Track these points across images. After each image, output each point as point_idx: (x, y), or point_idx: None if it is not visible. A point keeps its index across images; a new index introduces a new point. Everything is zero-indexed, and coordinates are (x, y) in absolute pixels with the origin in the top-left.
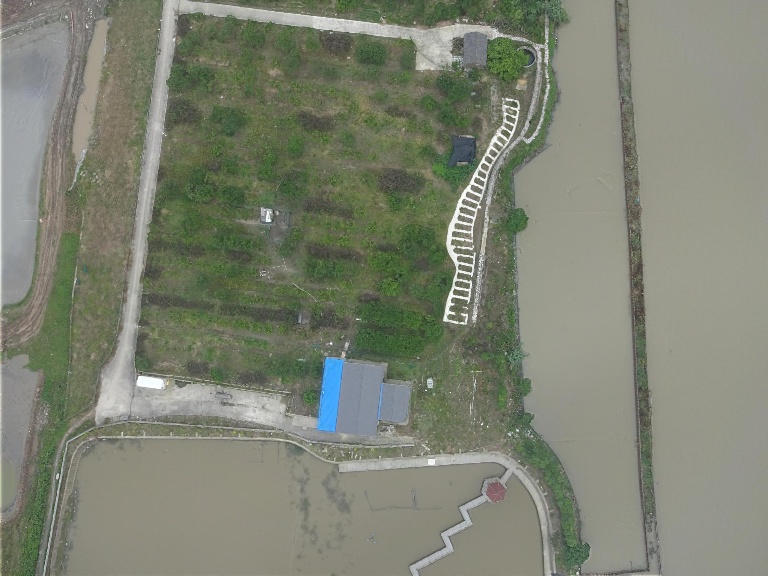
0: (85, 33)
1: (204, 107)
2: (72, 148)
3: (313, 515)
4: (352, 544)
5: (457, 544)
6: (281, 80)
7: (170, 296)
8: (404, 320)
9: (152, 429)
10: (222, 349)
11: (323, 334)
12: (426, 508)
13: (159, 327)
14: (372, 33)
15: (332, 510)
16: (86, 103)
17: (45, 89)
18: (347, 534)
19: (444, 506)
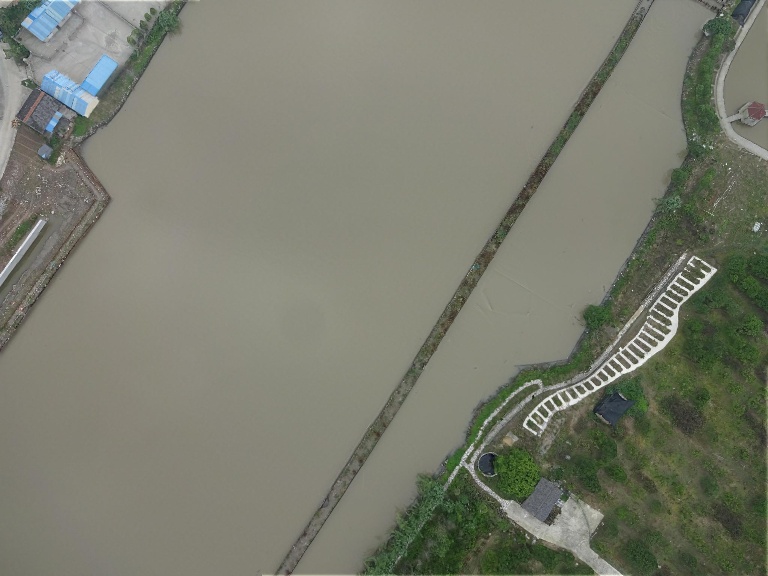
0: None
1: None
2: None
3: None
4: None
5: None
6: None
7: None
8: (760, 290)
9: None
10: None
11: None
12: None
13: None
14: None
15: None
16: None
17: None
18: None
19: None
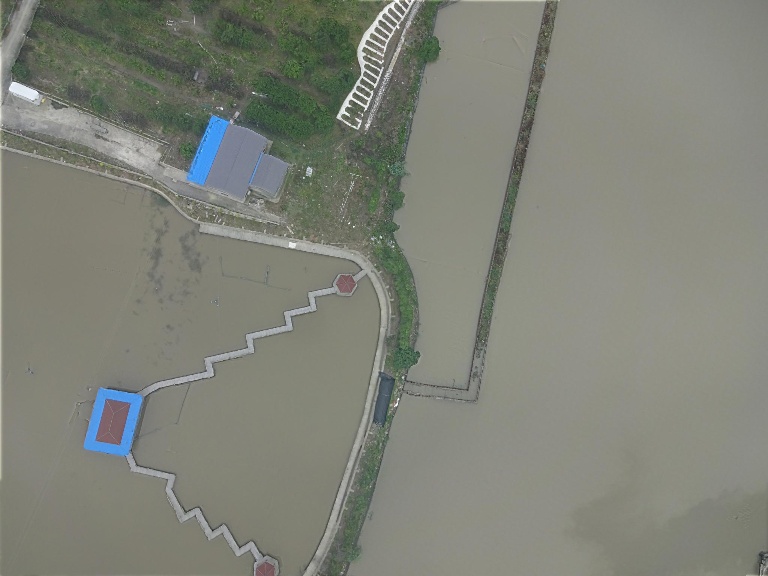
0: None
1: None
2: None
3: (163, 266)
4: (195, 303)
5: (297, 326)
6: None
7: (67, 16)
8: (298, 102)
9: (15, 141)
10: (109, 83)
11: (216, 96)
12: (276, 286)
13: (48, 43)
14: None
15: (183, 266)
16: None
17: None
18: (192, 291)
19: (294, 289)
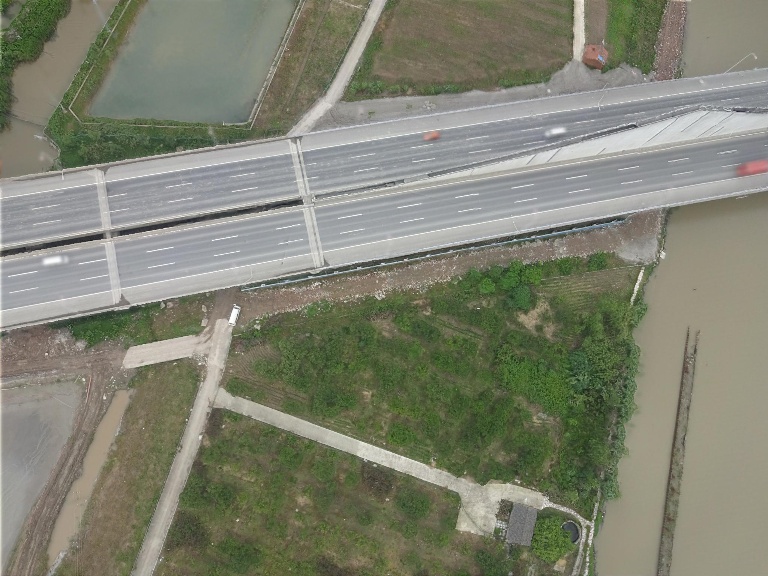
0: (100, 404)
1: (215, 529)
2: (48, 547)
3: None
4: None
5: None
6: (308, 512)
7: None
8: None
9: None
10: None
11: None
12: None
13: None
14: (418, 475)
15: None
16: (79, 492)
17: (35, 462)
18: None
19: None
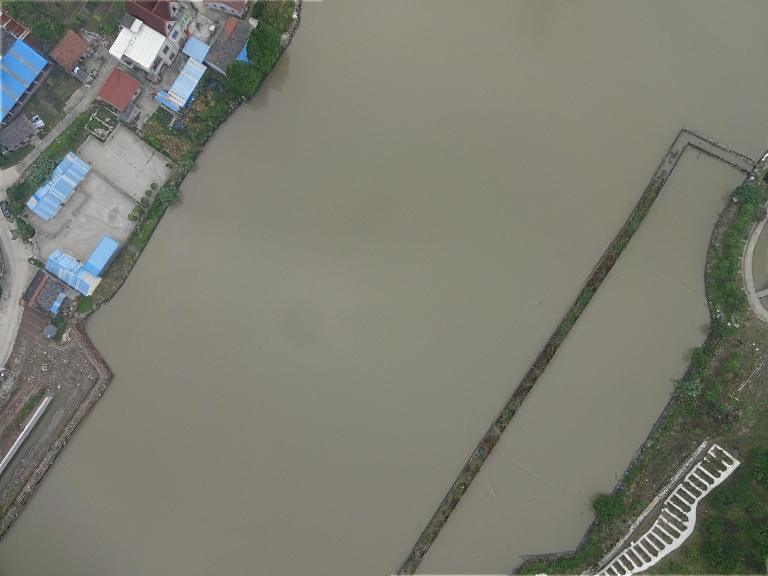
0: None
1: None
2: None
3: None
4: None
5: None
6: None
7: None
8: None
9: None
10: None
11: None
12: None
13: None
14: None
15: None
16: None
17: None
18: None
19: None
